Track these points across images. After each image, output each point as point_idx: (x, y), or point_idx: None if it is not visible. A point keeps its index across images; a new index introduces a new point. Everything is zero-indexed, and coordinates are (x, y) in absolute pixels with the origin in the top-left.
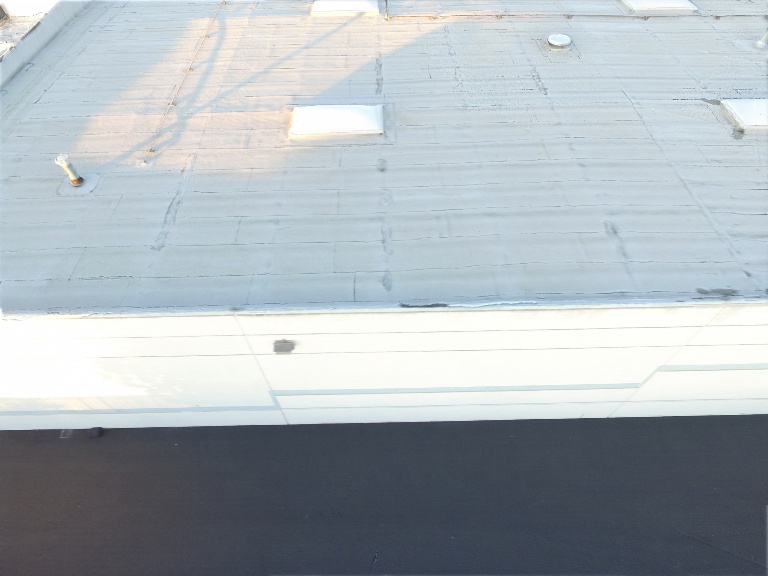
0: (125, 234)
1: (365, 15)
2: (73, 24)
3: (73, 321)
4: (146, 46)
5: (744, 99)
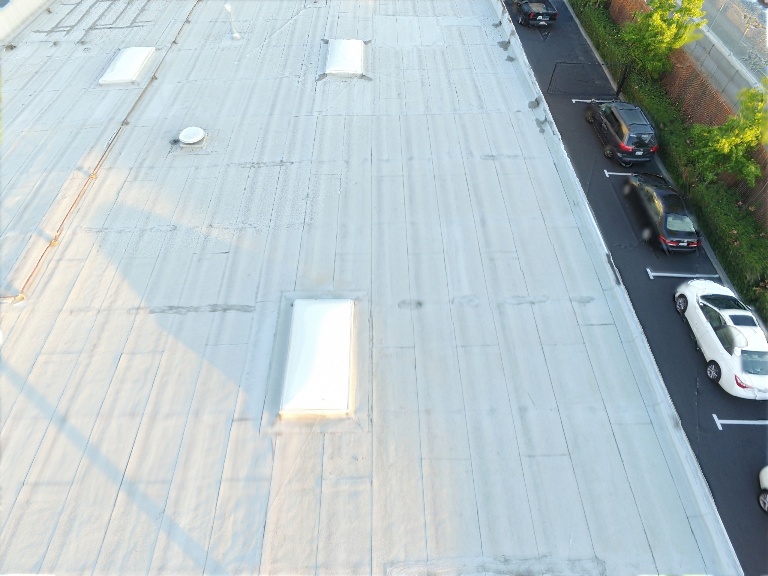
0: None
1: None
2: None
3: None
4: None
5: (329, 62)
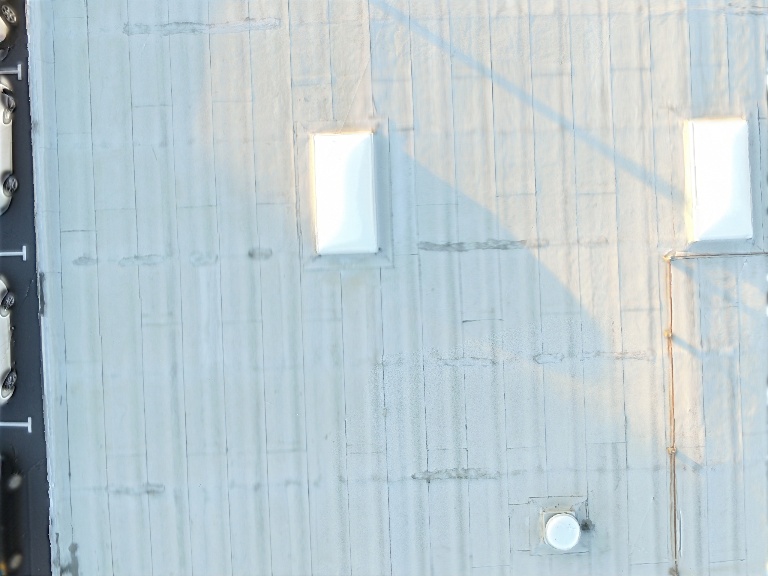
0: None
1: (688, 217)
2: None
3: None
4: None
5: None
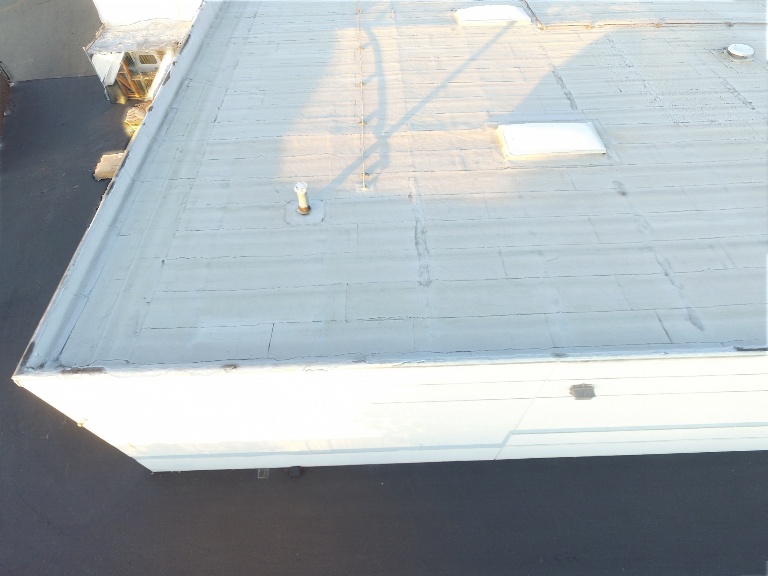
0: (382, 268)
1: (516, 24)
2: (212, 36)
3: (384, 370)
4: (302, 59)
5: None
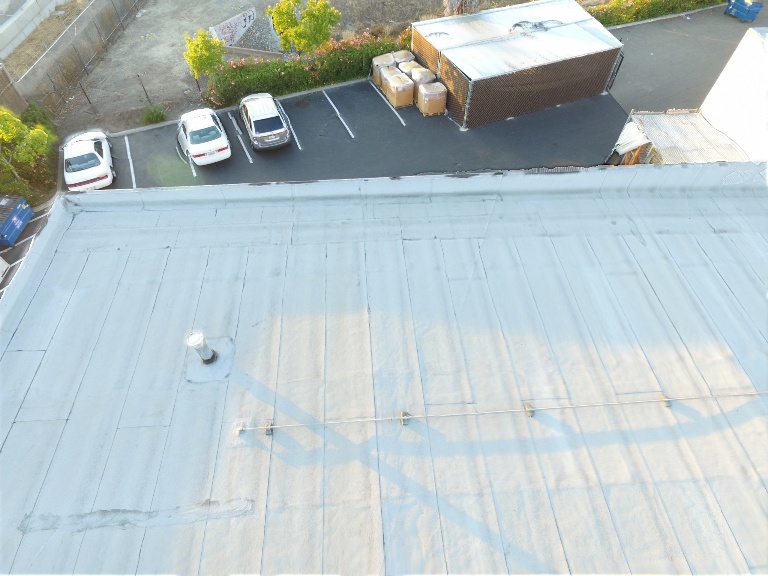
0: (77, 462)
1: None
2: (627, 197)
3: None
4: (594, 311)
5: None
